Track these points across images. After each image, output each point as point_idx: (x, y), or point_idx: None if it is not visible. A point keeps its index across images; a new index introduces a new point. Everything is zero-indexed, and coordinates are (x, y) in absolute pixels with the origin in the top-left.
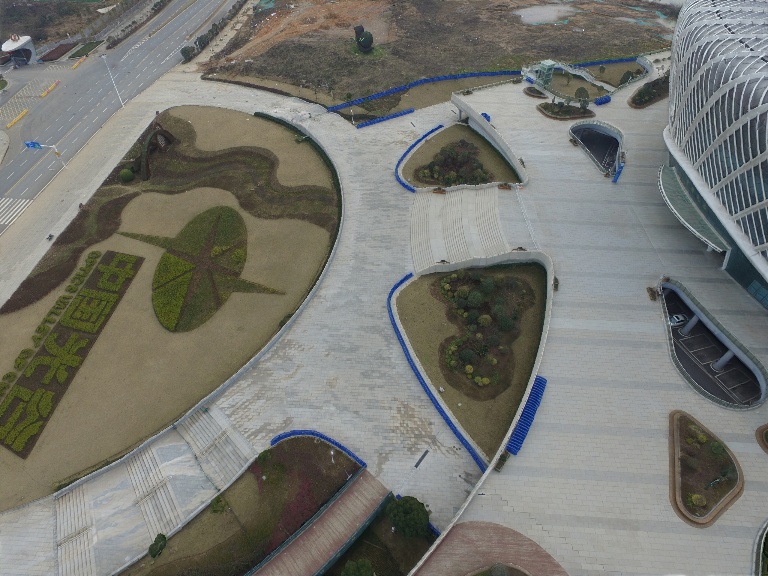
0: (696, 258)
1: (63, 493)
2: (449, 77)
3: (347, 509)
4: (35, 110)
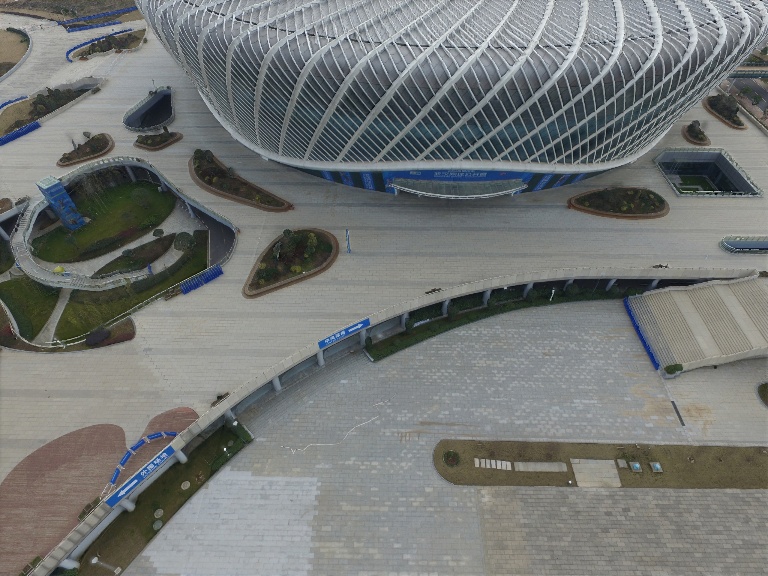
0: None
1: None
2: None
3: None
4: None
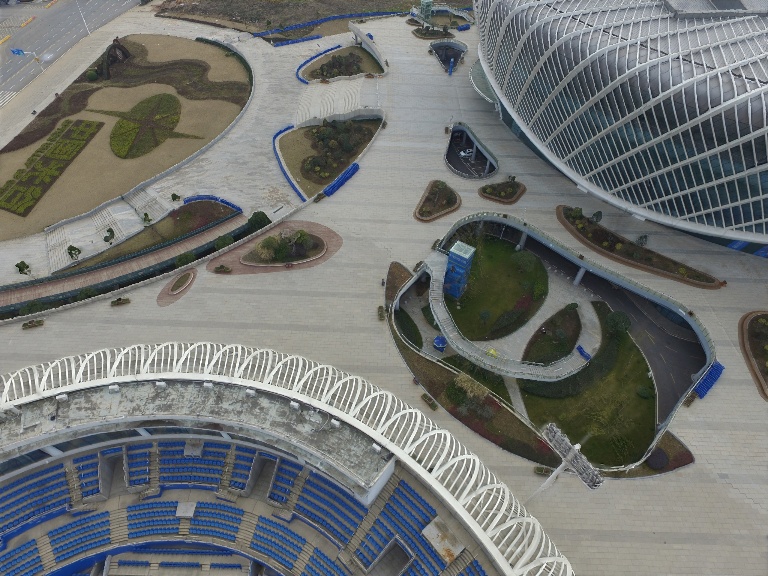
0: (486, 114)
1: (51, 230)
2: (355, 15)
3: (227, 228)
4: (16, 36)
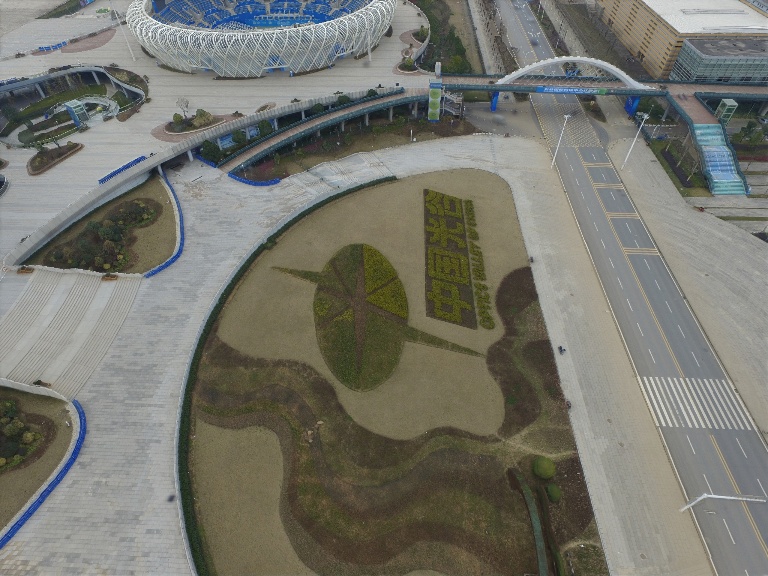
0: None
1: None
2: None
3: None
4: None
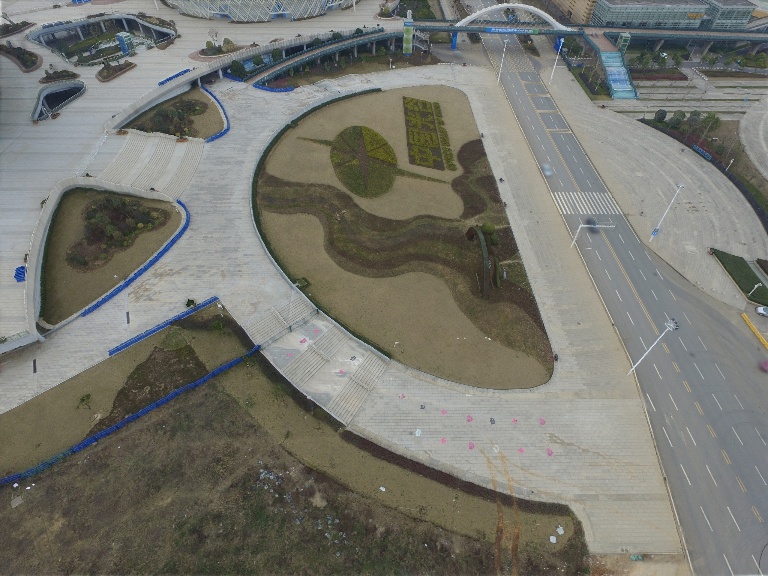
0: None
1: None
2: None
3: None
4: (767, 361)
